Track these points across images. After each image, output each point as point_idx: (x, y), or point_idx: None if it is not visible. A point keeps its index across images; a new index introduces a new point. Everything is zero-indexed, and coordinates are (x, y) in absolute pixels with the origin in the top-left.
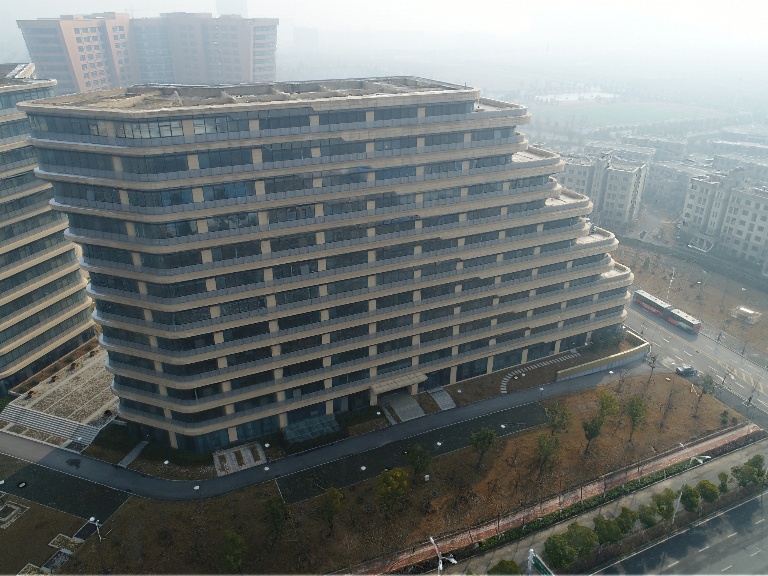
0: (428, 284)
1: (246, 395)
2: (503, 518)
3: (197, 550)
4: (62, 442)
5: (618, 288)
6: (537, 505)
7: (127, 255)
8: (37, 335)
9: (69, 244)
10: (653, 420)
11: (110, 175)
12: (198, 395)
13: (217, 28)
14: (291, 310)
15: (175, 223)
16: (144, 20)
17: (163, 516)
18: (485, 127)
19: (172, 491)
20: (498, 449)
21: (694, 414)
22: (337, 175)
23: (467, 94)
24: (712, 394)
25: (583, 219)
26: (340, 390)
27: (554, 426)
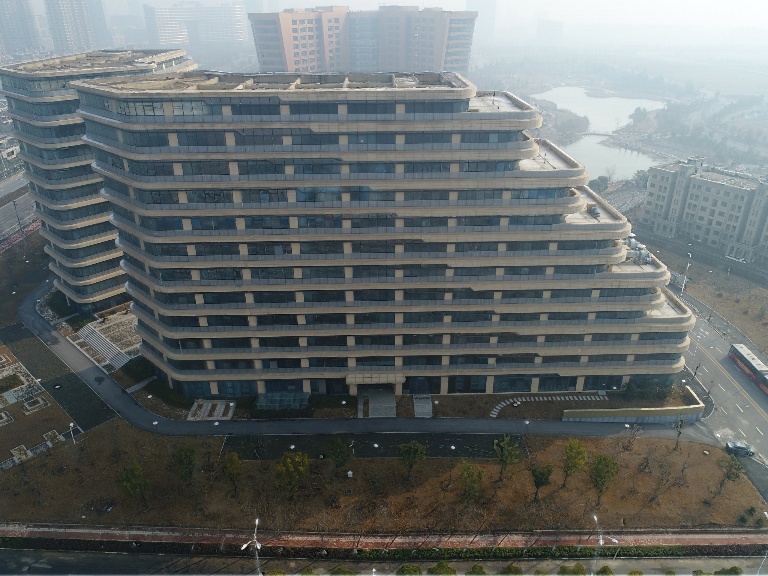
0: (409, 285)
1: (224, 355)
2: (402, 536)
3: (126, 472)
4: (103, 362)
5: (666, 332)
6: (446, 535)
7: (133, 214)
8: (122, 274)
9: None
10: (646, 491)
11: (117, 145)
12: (182, 346)
13: (419, 20)
14: (265, 286)
15: (159, 191)
16: (359, 13)
17: (126, 439)
18: (475, 129)
19: (146, 421)
20: (441, 469)
21: (707, 499)
22: (310, 164)
23: (452, 92)
24: (735, 482)
25: (619, 244)
26: (317, 372)
27: (504, 462)
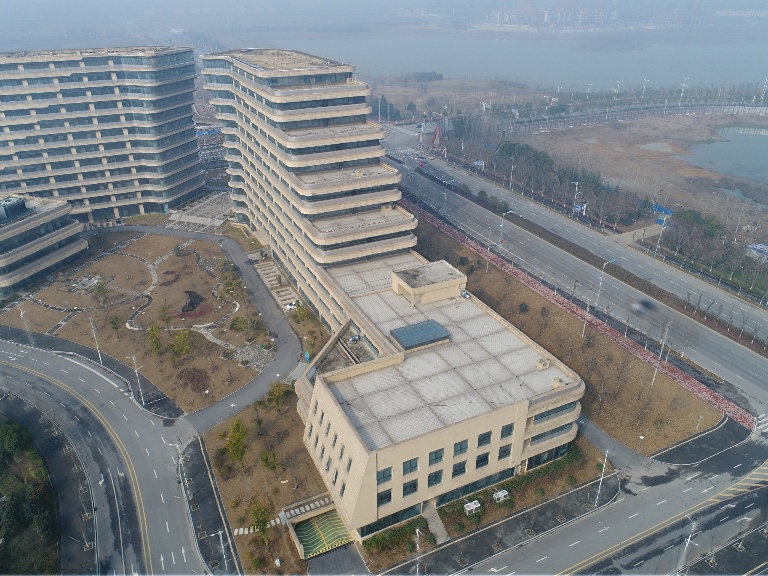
0: None
1: None
2: None
3: None
4: None
5: None
6: None
7: None
8: None
9: None
10: None
11: None
12: None
13: None
14: None
15: None
16: None
17: None
18: None
19: None
20: None
21: None
22: None
23: None
24: None
25: None
26: None
27: None
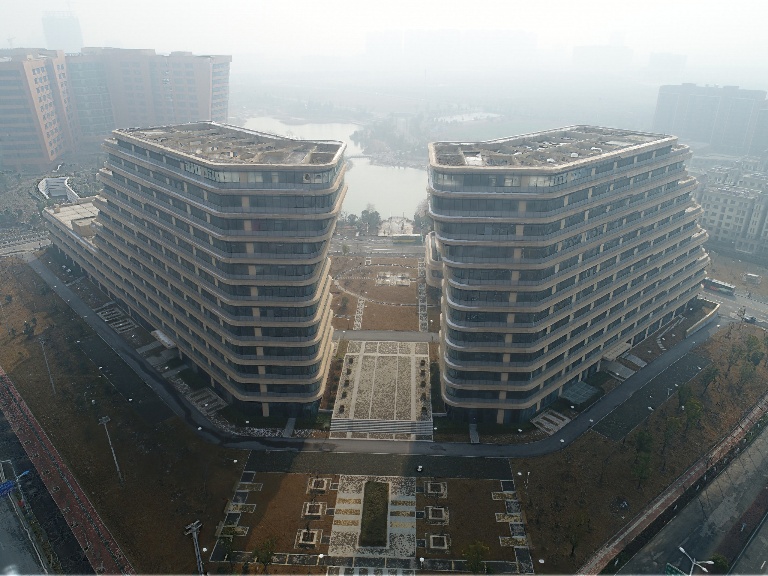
0: (638, 275)
1: (553, 372)
2: (741, 423)
3: (602, 477)
4: (409, 437)
5: None
6: (751, 412)
7: (505, 274)
8: None
9: (329, 278)
10: (764, 352)
11: (513, 215)
12: (532, 376)
13: (168, 65)
14: (582, 303)
15: (550, 246)
16: (80, 57)
17: (548, 465)
18: (677, 161)
19: (533, 450)
20: None
21: None
22: (616, 202)
23: (675, 140)
24: None
25: None
26: (588, 362)
27: (731, 362)
